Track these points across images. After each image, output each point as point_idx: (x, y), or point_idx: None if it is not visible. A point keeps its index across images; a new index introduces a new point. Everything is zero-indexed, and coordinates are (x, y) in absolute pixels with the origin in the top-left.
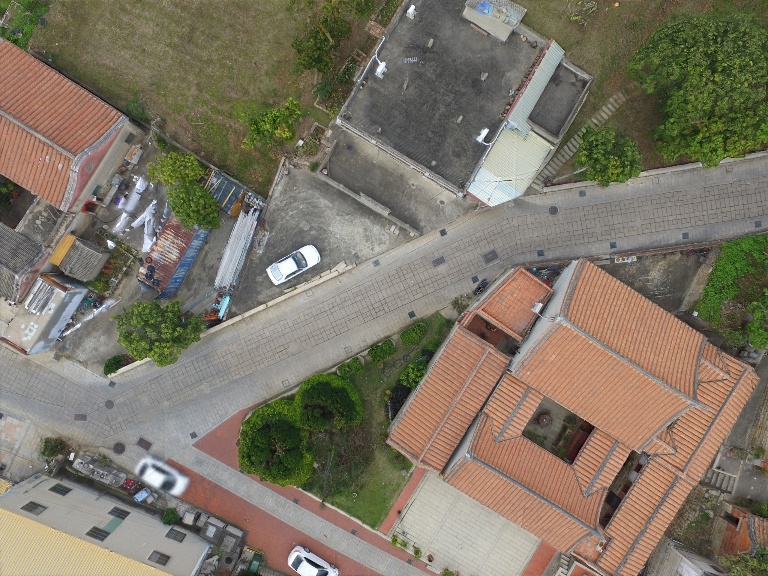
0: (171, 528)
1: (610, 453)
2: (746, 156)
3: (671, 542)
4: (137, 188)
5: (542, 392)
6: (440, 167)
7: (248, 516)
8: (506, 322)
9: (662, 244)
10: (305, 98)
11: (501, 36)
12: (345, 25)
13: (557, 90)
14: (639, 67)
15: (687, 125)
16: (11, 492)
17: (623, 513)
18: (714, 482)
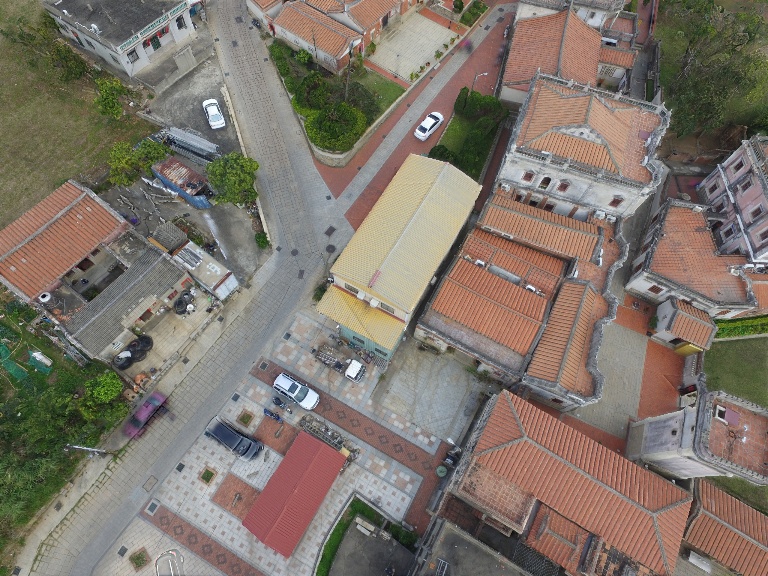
0: None
1: None
2: None
3: None
4: None
5: None
6: None
7: (392, 167)
8: None
9: None
10: None
11: None
12: None
13: None
14: None
15: None
16: None
17: None
18: None
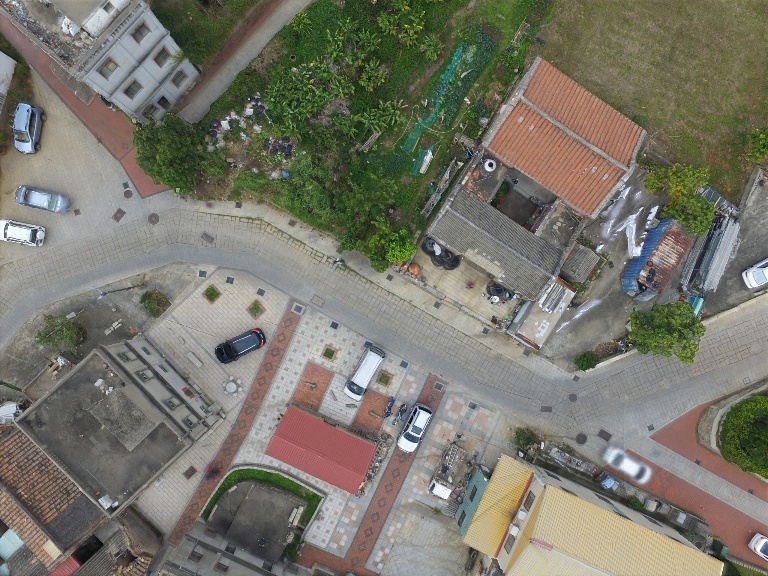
0: (641, 514)
1: None
2: None
3: None
4: (624, 196)
5: None
6: None
7: (704, 504)
8: None
9: None
10: None
11: None
12: None
13: None
14: None
15: None
16: (540, 476)
17: None
18: None
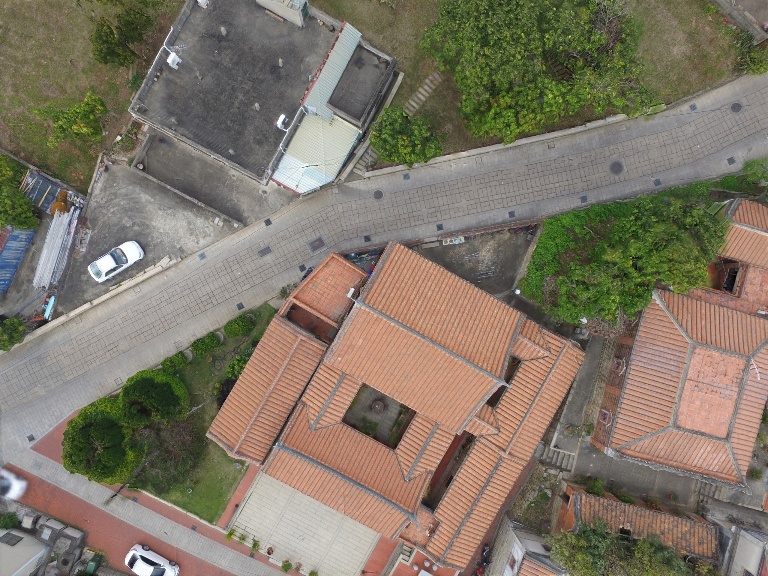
0: (7, 532)
1: (430, 436)
2: (566, 131)
3: (510, 523)
4: None
5: (356, 377)
6: (241, 156)
7: (88, 517)
8: (321, 309)
9: (489, 224)
10: (122, 94)
11: (295, 21)
12: (140, 18)
13: (360, 73)
14: (427, 45)
15: (482, 102)
16: None
17: (450, 496)
18: (555, 461)
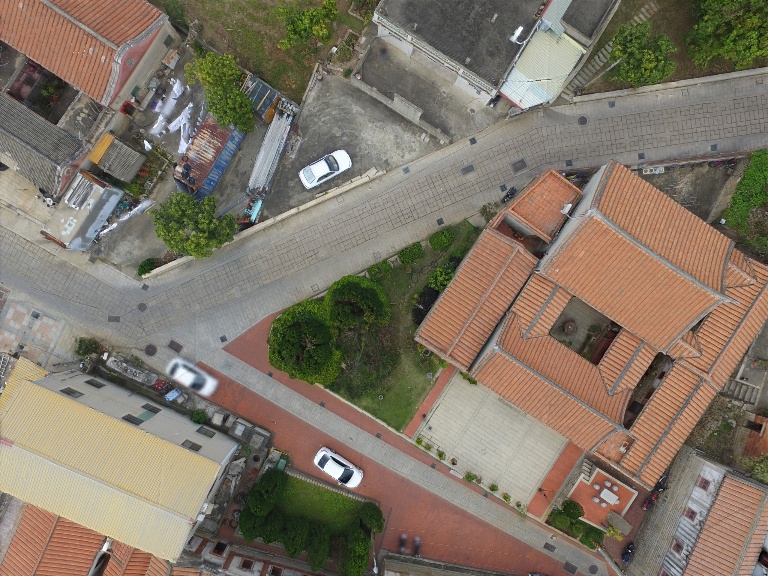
0: (201, 426)
1: (636, 353)
2: None
3: (693, 450)
4: (174, 91)
5: (570, 290)
6: (473, 66)
7: (276, 418)
8: (535, 223)
9: (690, 156)
10: (339, 6)
11: None
12: None
13: None
14: None
15: (720, 24)
16: (50, 378)
17: (647, 415)
18: (737, 394)
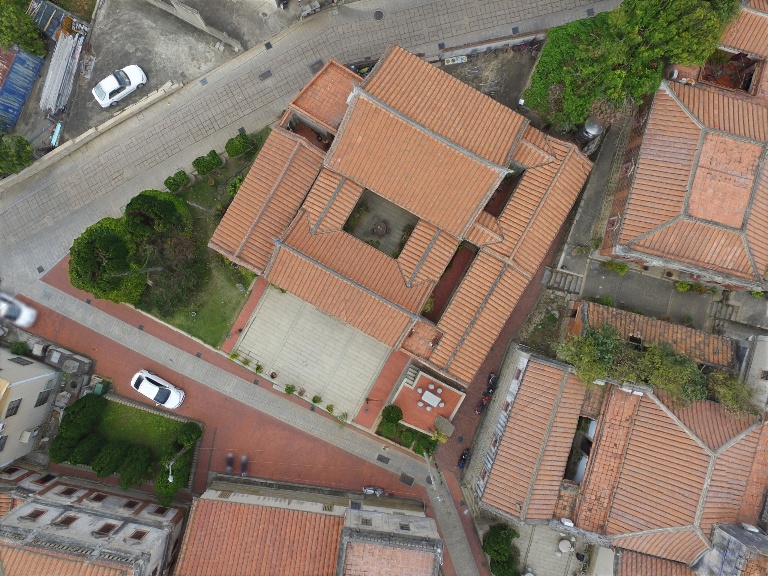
0: (18, 357)
1: (432, 241)
2: None
3: (516, 345)
4: None
5: (356, 181)
6: None
7: (96, 345)
8: (321, 117)
9: None
10: None
11: None
12: None
13: None
14: None
15: None
16: None
17: (454, 307)
18: (563, 286)
